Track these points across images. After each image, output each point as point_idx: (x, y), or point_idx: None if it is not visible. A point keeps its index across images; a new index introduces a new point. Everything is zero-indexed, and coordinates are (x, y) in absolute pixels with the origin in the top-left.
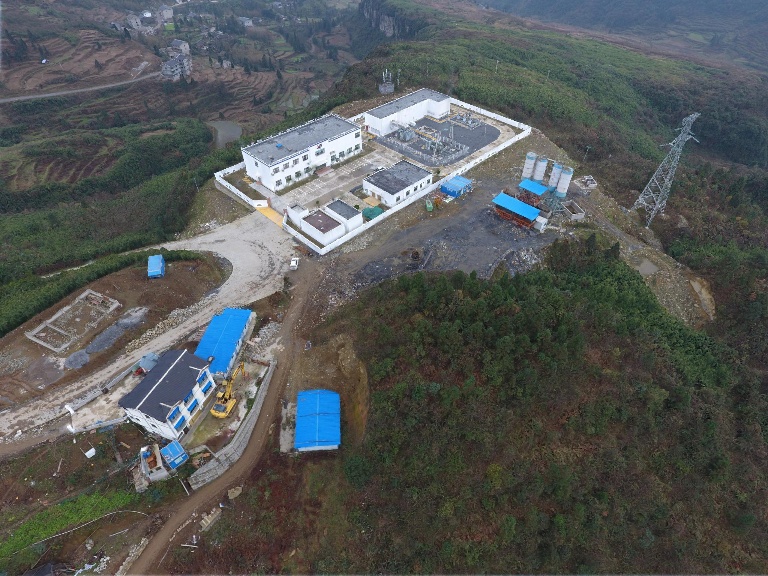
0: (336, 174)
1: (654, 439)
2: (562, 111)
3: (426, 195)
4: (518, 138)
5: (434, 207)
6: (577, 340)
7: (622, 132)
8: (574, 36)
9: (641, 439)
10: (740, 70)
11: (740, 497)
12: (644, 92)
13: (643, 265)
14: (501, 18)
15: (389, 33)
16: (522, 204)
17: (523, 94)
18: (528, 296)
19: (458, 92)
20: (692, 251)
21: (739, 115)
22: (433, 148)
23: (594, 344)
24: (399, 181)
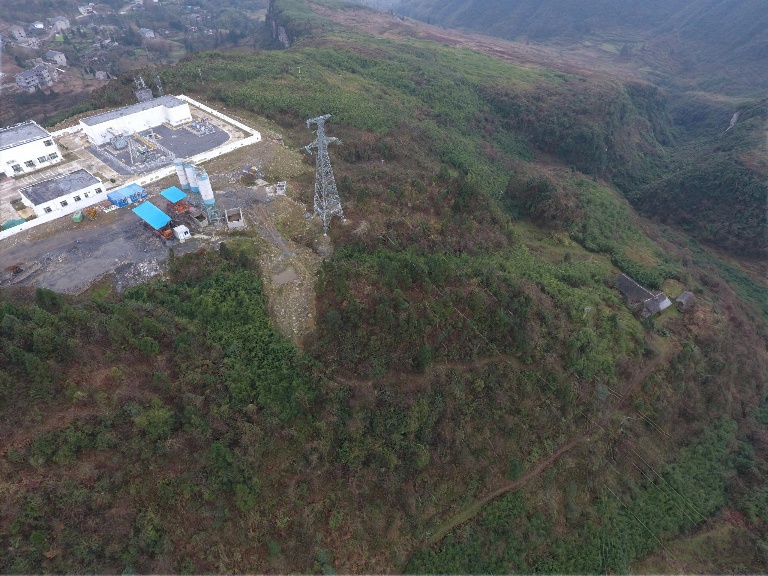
0: (12, 185)
1: (149, 466)
2: (342, 117)
3: (93, 205)
4: (242, 144)
5: (86, 218)
6: (25, 361)
7: (435, 138)
8: (463, 46)
9: (134, 467)
10: (614, 78)
11: (277, 523)
12: (489, 99)
13: (283, 274)
14: (393, 28)
15: (287, 44)
16: (158, 213)
17: (305, 100)
18: (29, 313)
19: (225, 99)
20: (353, 257)
21: (576, 120)
22: (138, 156)
23: (112, 363)
24: (58, 191)
